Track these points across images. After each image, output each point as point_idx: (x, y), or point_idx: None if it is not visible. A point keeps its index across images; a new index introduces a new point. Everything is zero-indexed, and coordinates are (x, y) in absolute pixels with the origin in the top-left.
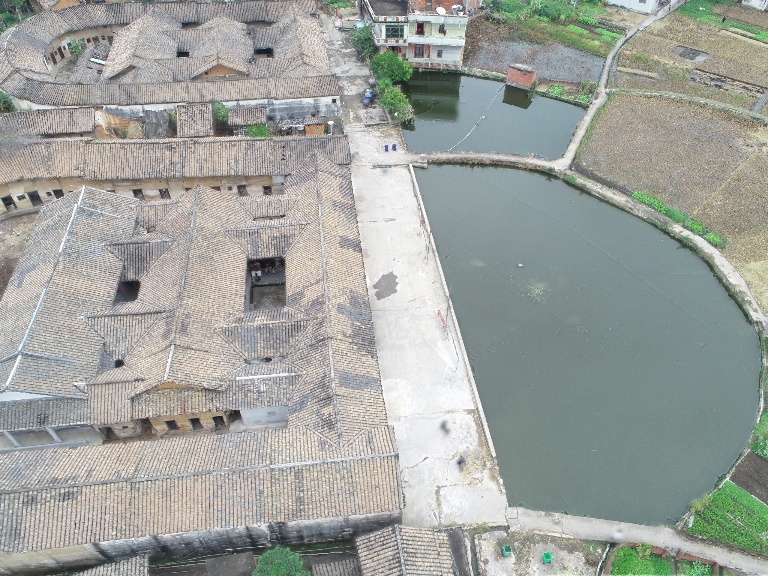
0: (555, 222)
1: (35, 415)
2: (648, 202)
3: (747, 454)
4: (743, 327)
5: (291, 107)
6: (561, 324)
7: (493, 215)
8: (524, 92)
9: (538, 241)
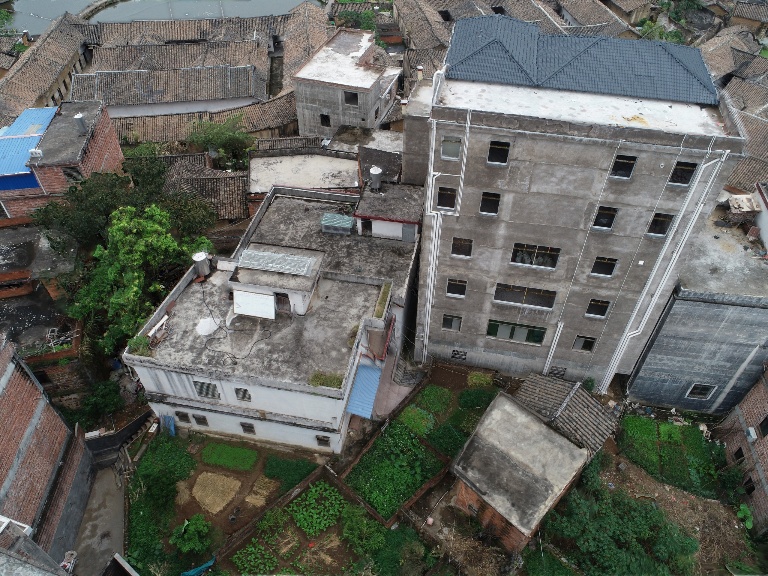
0: (157, 6)
1: (260, 81)
2: None
3: None
4: None
5: None
6: (230, 10)
7: (141, 19)
8: (7, 3)
9: (171, 10)
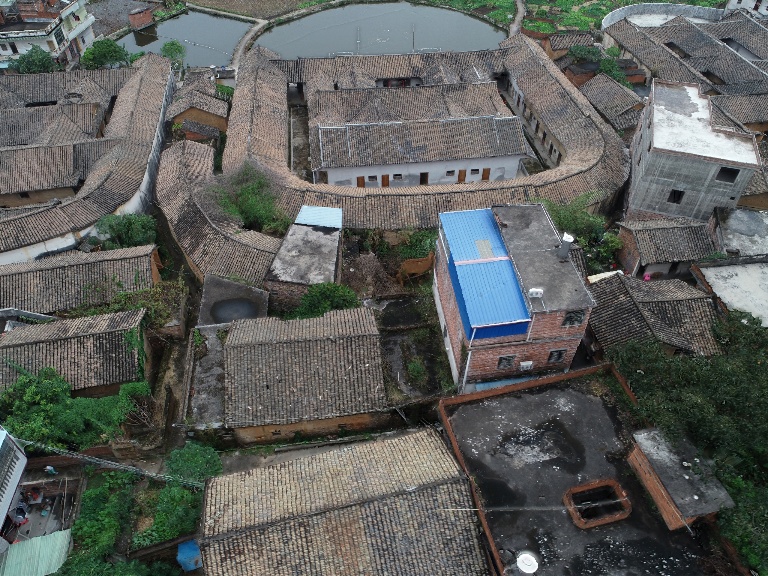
0: (320, 31)
1: None
2: (308, 5)
3: (473, 11)
4: (401, 4)
5: None
6: None
7: (309, 47)
8: (152, 27)
9: (337, 36)
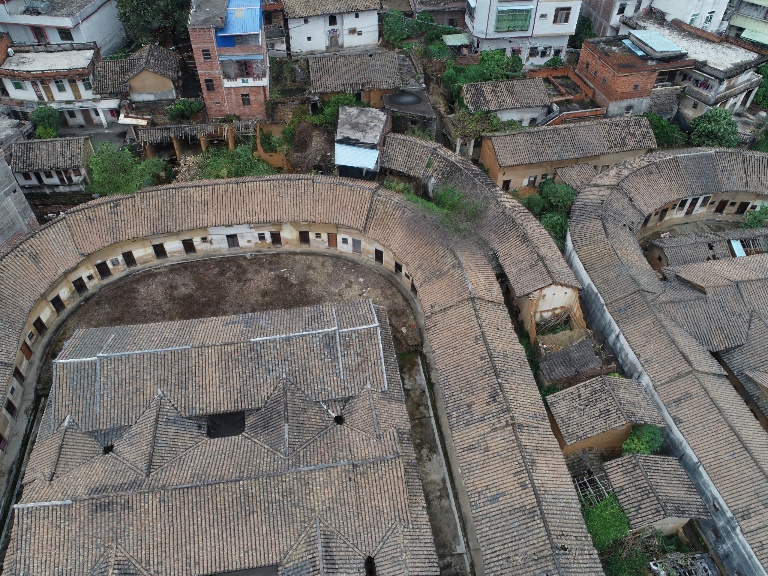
0: None
1: None
2: None
3: None
4: None
5: (753, 569)
6: None
7: None
8: None
9: None
